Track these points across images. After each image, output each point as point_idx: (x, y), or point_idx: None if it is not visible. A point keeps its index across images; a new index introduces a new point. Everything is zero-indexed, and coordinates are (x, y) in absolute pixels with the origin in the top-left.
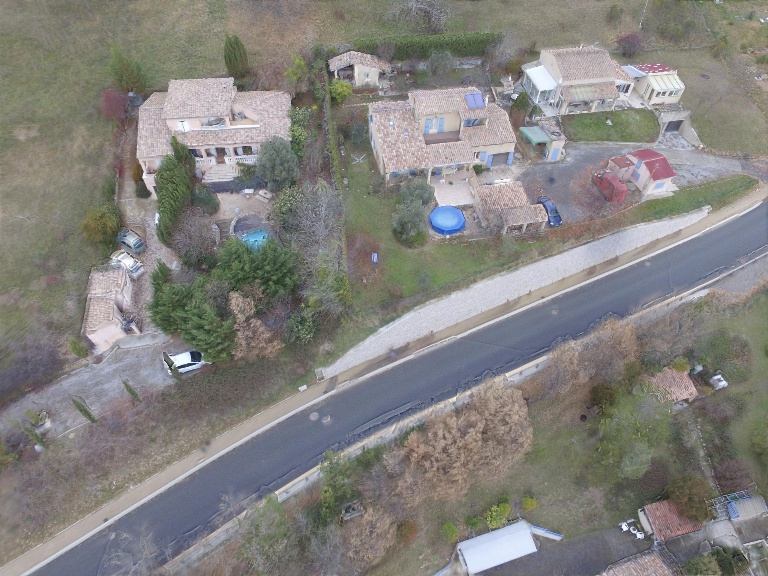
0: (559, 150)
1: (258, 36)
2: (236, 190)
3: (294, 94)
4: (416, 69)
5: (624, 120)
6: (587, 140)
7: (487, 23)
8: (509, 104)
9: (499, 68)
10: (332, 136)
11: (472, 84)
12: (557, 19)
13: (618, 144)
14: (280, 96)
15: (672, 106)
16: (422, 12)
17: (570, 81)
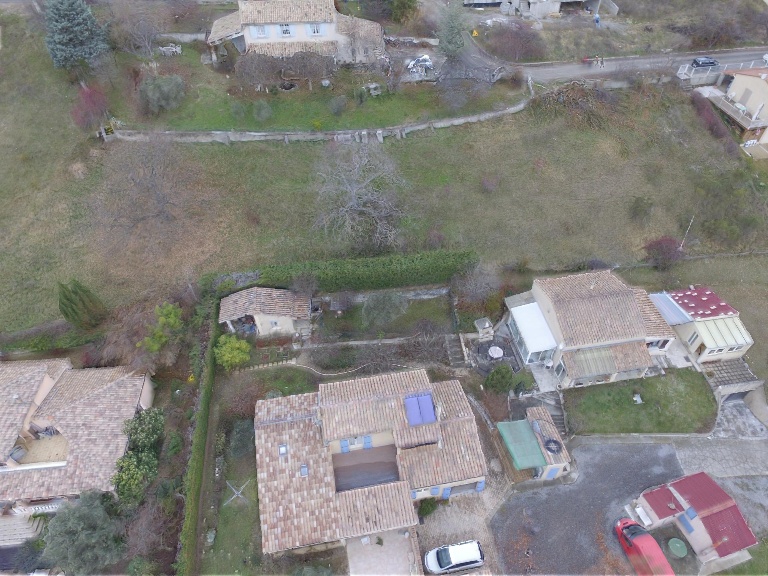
0: (559, 469)
1: (134, 253)
2: (23, 567)
3: (153, 371)
4: (352, 302)
5: (661, 394)
6: (604, 432)
7: (459, 225)
8: (485, 363)
9: (473, 301)
10: (193, 461)
11: (430, 334)
12: (558, 217)
13: (653, 437)
14: (125, 383)
15: (733, 365)
16: (365, 216)
17: (576, 345)
